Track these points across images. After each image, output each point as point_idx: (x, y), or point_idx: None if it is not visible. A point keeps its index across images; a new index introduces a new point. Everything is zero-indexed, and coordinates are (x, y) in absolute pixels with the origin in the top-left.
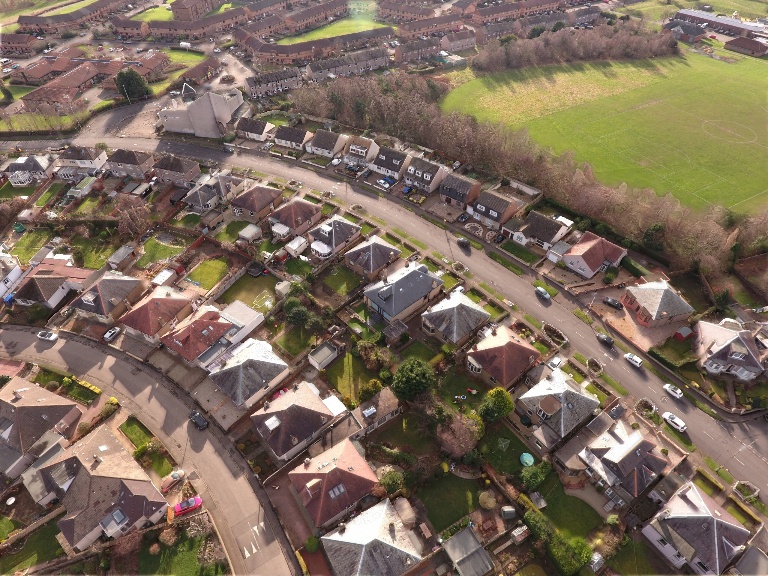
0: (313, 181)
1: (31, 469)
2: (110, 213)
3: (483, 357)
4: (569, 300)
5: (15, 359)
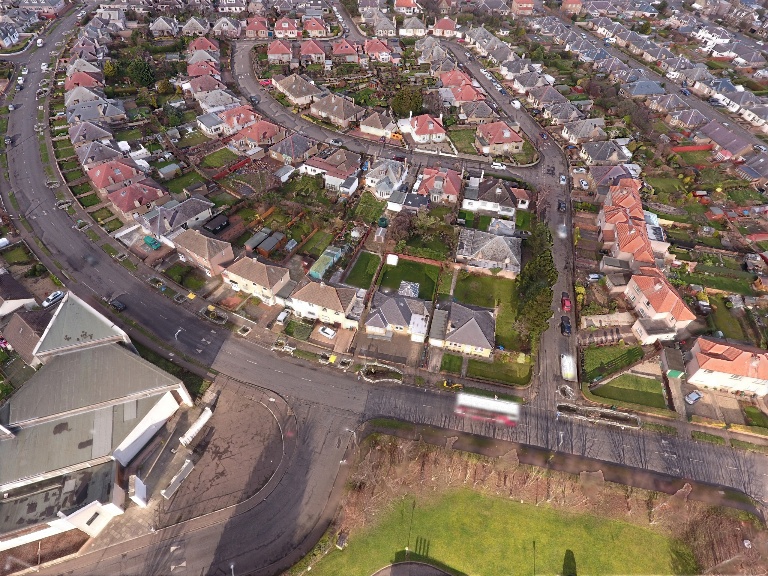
0: (58, 226)
1: (327, 93)
2: (293, 219)
3: (97, 79)
4: (3, 103)
5: (353, 137)
